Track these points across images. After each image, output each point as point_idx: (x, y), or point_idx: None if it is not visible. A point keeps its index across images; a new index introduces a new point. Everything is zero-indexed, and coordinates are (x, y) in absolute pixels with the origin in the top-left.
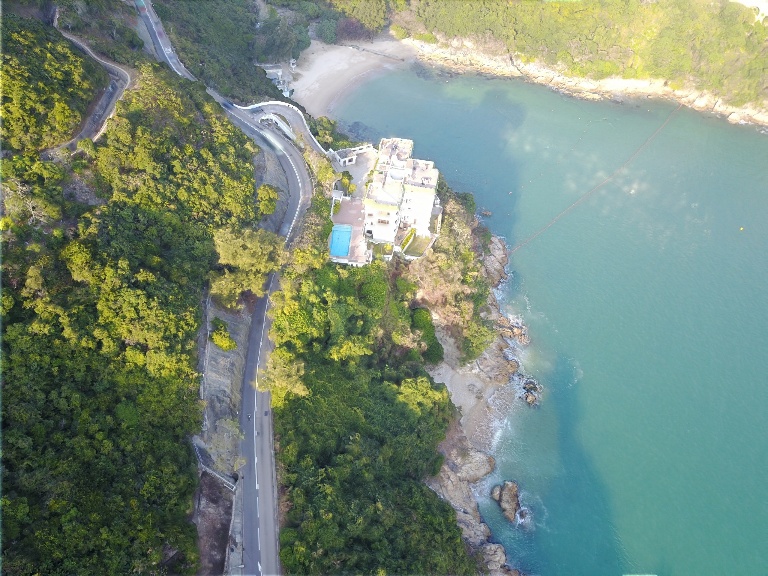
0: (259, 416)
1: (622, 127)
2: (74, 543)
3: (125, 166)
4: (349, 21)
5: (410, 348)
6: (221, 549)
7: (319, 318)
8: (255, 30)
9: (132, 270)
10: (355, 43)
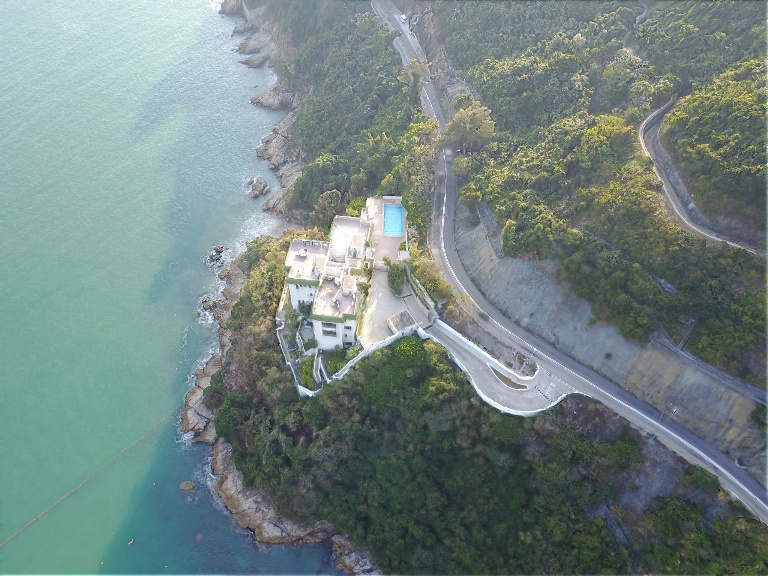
0: None
1: None
2: (485, 3)
3: None
4: None
5: None
6: None
7: None
8: None
9: None
10: None
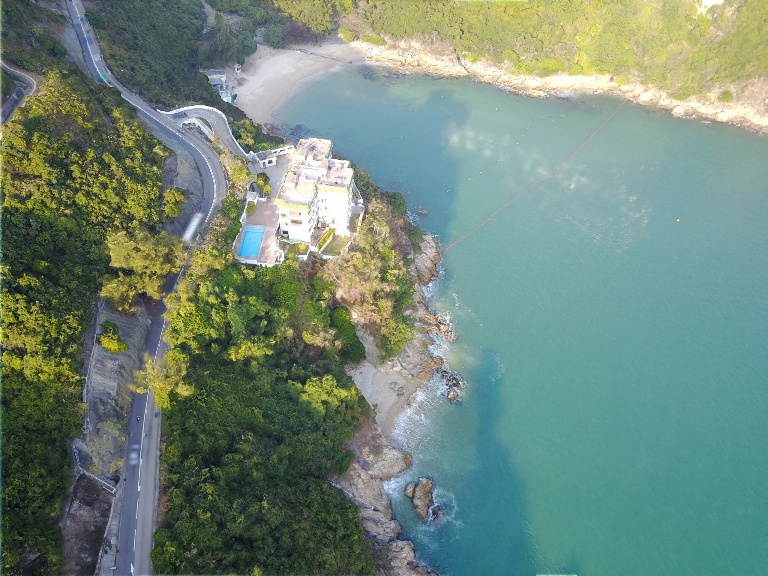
0: (149, 418)
1: (566, 123)
2: None
3: (20, 172)
4: (295, 25)
5: (322, 347)
6: (93, 551)
7: (218, 319)
8: (200, 36)
9: (15, 275)
10: (303, 47)
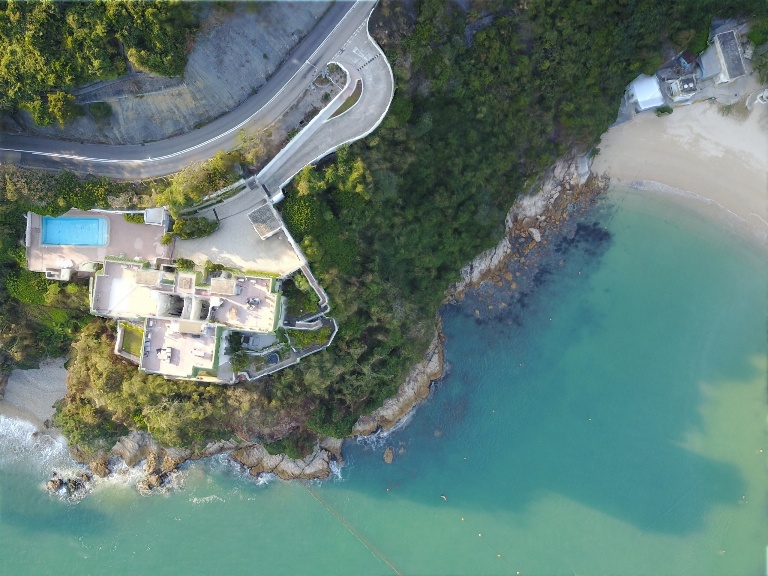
0: None
1: None
2: None
3: None
4: None
5: None
6: None
7: None
8: None
9: None
10: None
